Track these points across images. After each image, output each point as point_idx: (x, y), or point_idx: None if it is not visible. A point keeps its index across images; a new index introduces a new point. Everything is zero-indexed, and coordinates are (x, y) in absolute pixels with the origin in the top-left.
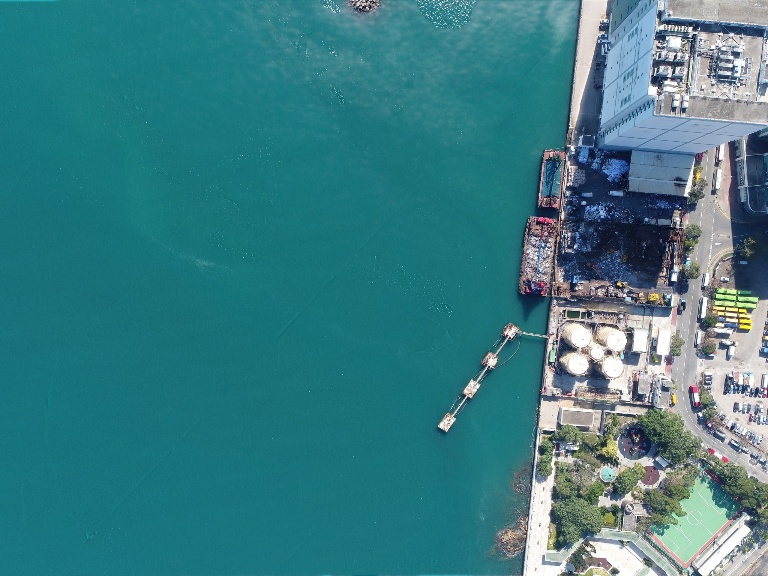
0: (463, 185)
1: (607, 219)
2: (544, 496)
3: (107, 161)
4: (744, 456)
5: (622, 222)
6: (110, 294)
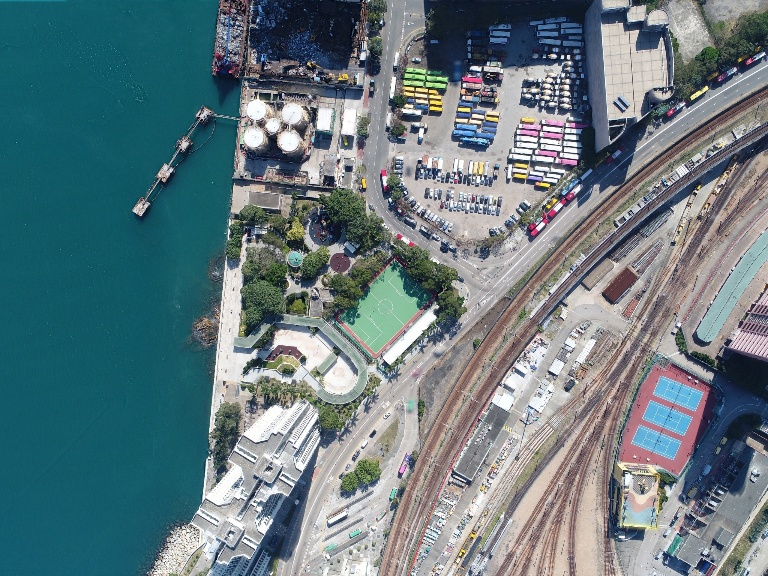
0: None
1: None
2: (236, 283)
3: None
4: (435, 244)
5: None
6: None
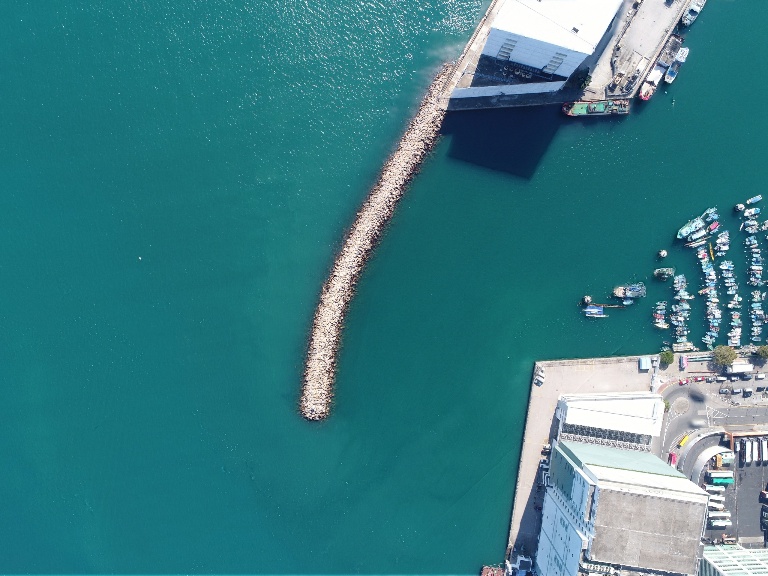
0: None
1: None
2: None
3: (56, 542)
4: None
5: None
6: None
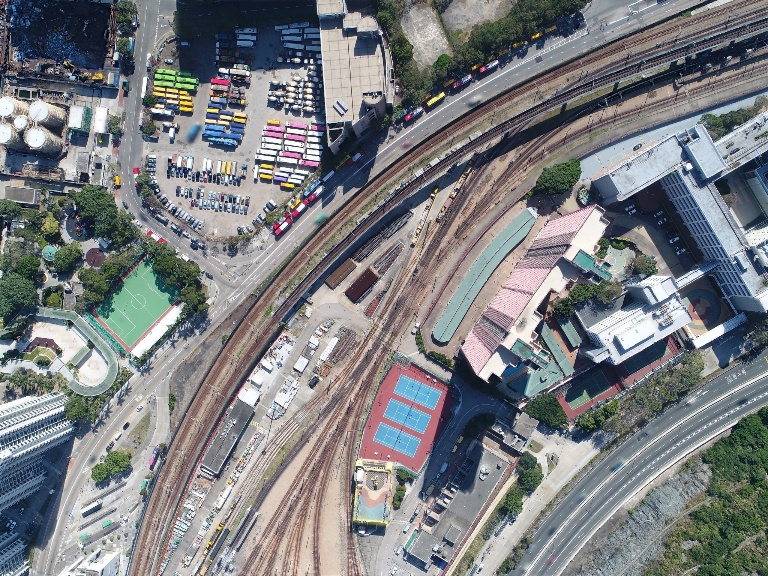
0: None
1: None
2: None
3: None
4: (186, 241)
5: (68, 0)
6: None
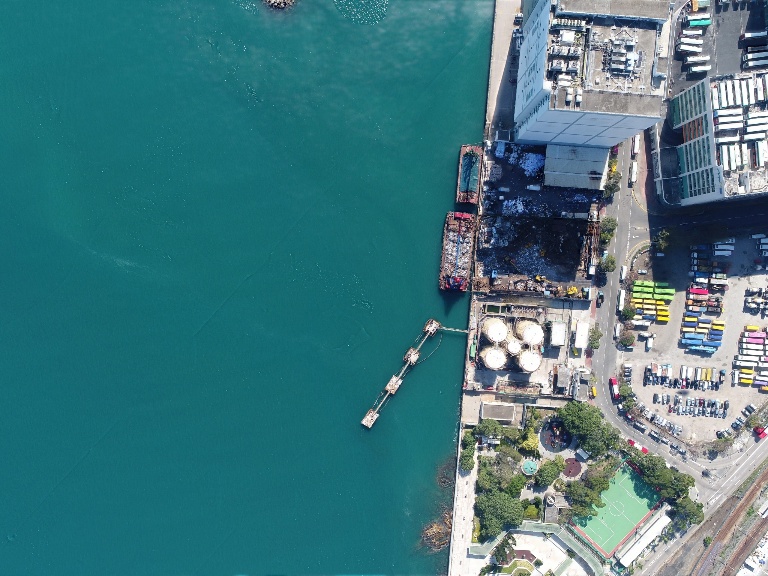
0: (382, 181)
1: (525, 213)
2: (468, 490)
3: (26, 162)
4: (664, 447)
5: (540, 216)
6: (32, 296)
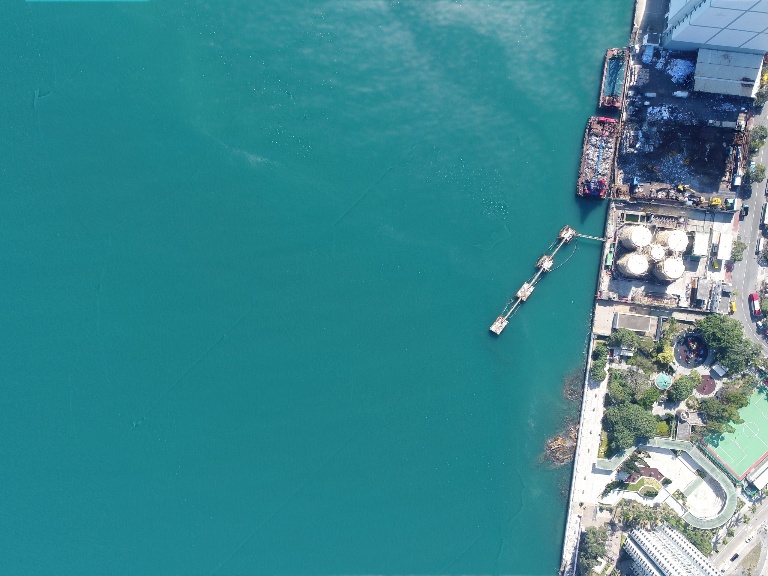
0: (523, 84)
1: (670, 120)
2: (596, 403)
3: (163, 54)
4: None
5: (685, 124)
6: (162, 189)
